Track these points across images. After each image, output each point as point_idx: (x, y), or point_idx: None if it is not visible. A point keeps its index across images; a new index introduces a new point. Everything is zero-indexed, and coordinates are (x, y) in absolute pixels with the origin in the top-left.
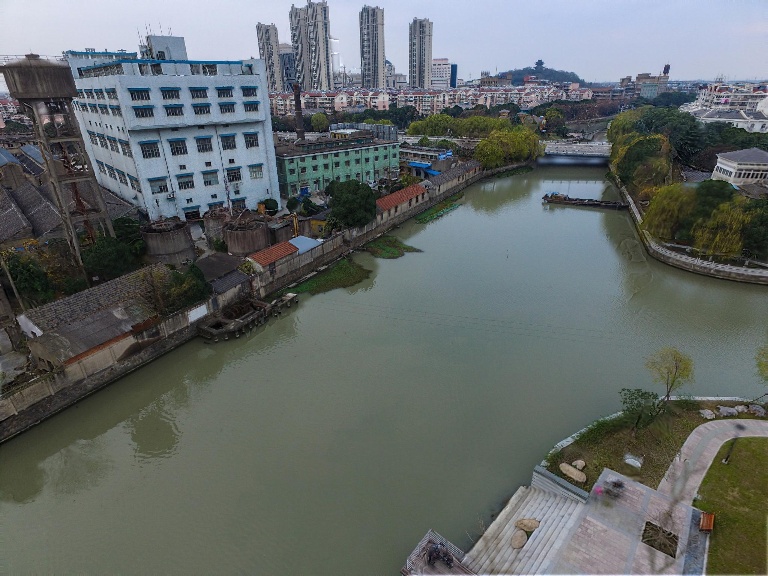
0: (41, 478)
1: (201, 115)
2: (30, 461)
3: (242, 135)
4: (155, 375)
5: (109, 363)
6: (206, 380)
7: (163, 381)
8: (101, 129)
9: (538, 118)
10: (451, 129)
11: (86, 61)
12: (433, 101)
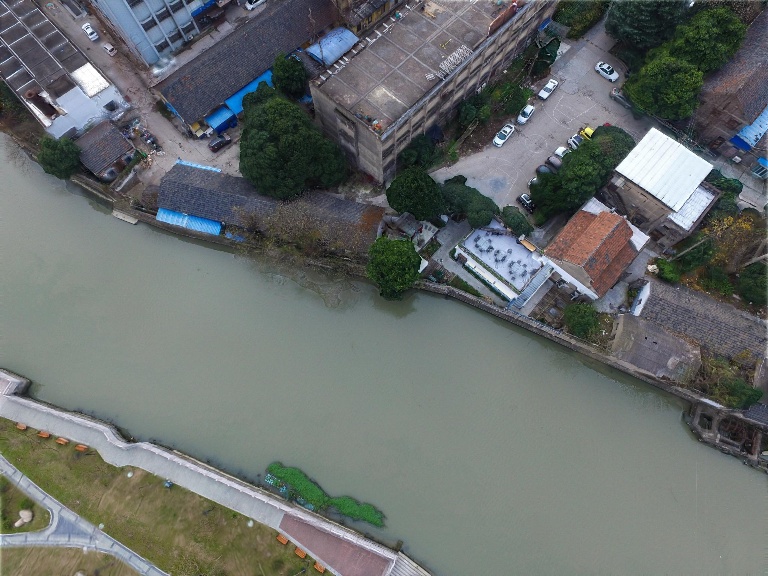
0: None
1: None
2: (556, 348)
3: None
4: (641, 385)
5: None
6: (664, 402)
7: (642, 387)
8: None
9: None
10: None
11: None
12: None
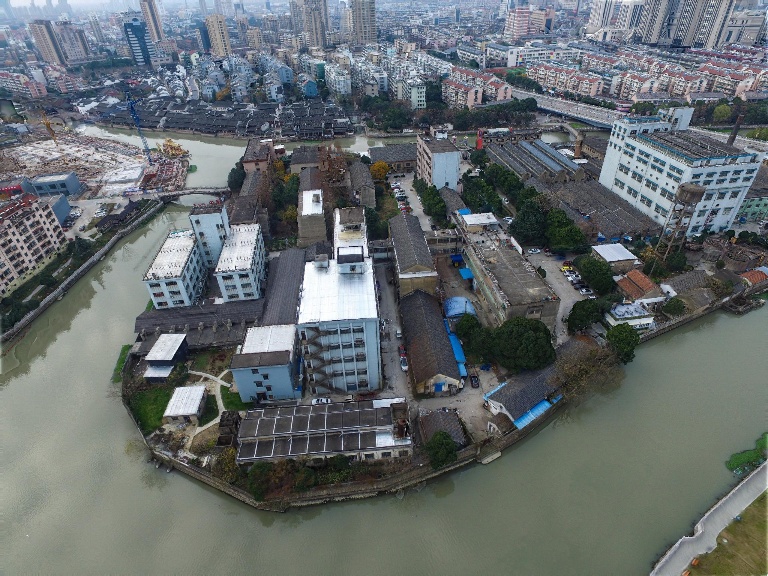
0: (667, 340)
1: (718, 184)
2: None
3: (731, 192)
4: None
5: (700, 312)
6: (710, 325)
7: (704, 321)
8: (642, 172)
9: None
10: None
11: (637, 127)
12: None
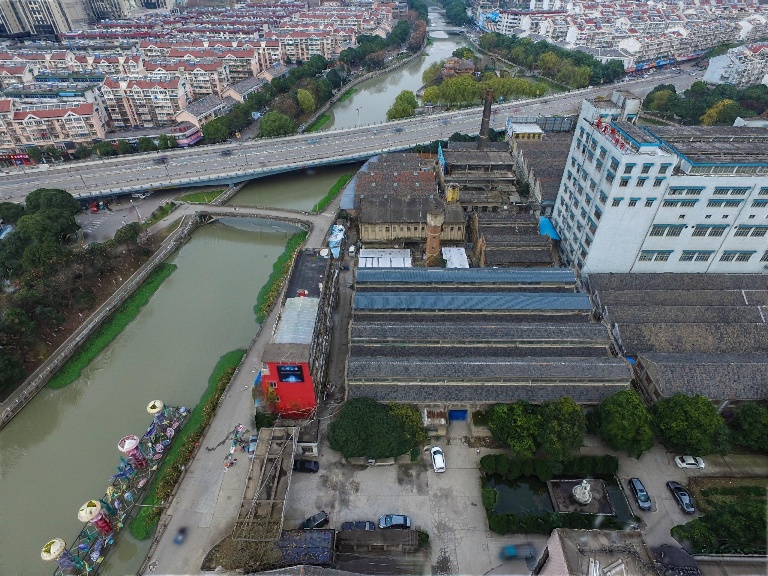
0: None
1: None
2: None
3: None
4: None
5: None
6: None
7: None
8: (724, 220)
9: (468, 61)
10: (480, 93)
11: None
12: (322, 44)
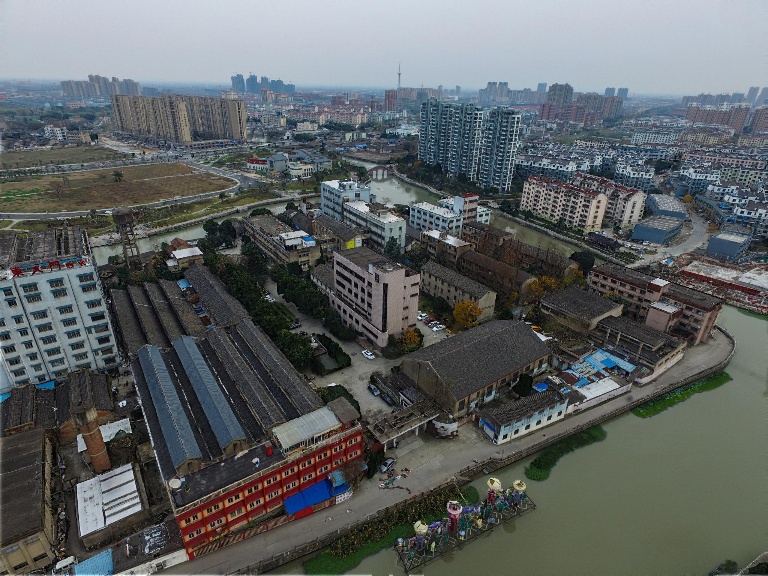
0: None
1: None
2: None
3: None
4: None
5: None
6: None
7: None
8: None
9: None
10: None
11: None
12: None
